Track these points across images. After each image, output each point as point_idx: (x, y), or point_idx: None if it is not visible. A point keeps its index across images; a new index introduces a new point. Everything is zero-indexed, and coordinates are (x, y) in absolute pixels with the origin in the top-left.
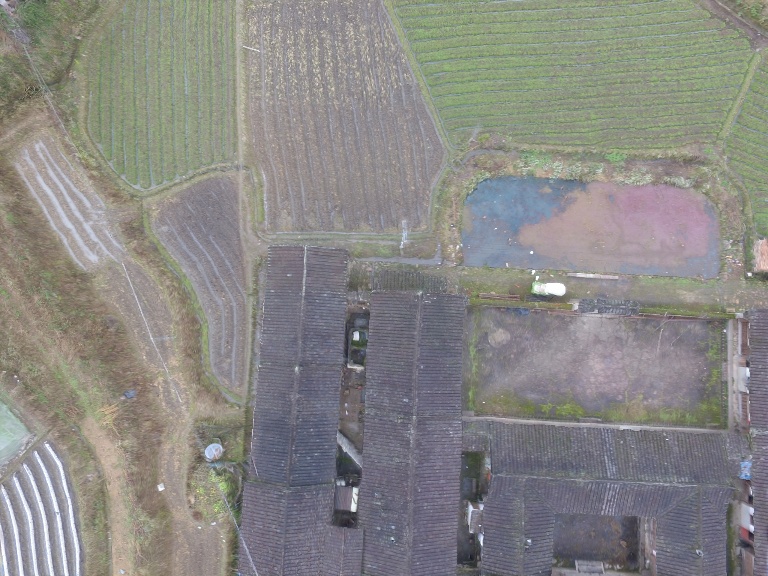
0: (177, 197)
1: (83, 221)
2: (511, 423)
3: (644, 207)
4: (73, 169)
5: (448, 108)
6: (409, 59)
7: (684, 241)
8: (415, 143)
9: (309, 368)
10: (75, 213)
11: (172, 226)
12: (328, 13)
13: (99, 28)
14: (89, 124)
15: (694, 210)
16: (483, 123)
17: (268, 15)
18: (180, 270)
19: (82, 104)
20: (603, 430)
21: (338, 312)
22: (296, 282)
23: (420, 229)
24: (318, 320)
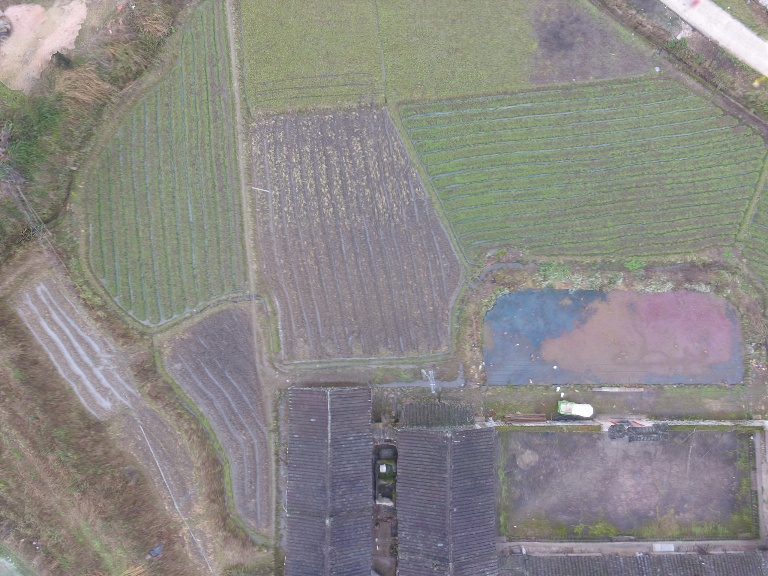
0: (189, 333)
1: (92, 367)
2: (544, 547)
3: (665, 314)
4: (78, 312)
5: (463, 222)
6: (420, 173)
7: (707, 347)
8: (431, 261)
9: (339, 517)
10: (83, 358)
11: (185, 363)
12: (333, 127)
13: (95, 156)
14: (91, 259)
15: (715, 314)
16: (499, 236)
17: (271, 133)
18: (197, 409)
19: (82, 239)
20: (639, 558)
21: (365, 453)
22: (321, 428)
23: (441, 350)
24: (345, 465)
